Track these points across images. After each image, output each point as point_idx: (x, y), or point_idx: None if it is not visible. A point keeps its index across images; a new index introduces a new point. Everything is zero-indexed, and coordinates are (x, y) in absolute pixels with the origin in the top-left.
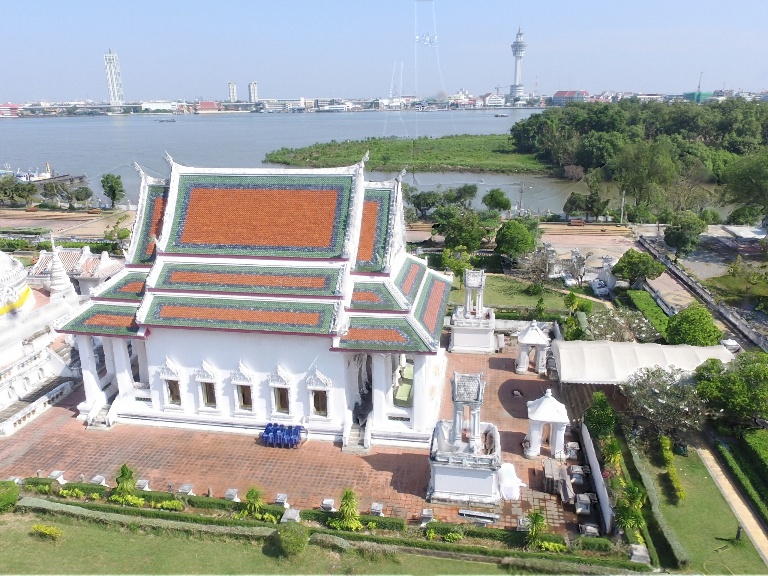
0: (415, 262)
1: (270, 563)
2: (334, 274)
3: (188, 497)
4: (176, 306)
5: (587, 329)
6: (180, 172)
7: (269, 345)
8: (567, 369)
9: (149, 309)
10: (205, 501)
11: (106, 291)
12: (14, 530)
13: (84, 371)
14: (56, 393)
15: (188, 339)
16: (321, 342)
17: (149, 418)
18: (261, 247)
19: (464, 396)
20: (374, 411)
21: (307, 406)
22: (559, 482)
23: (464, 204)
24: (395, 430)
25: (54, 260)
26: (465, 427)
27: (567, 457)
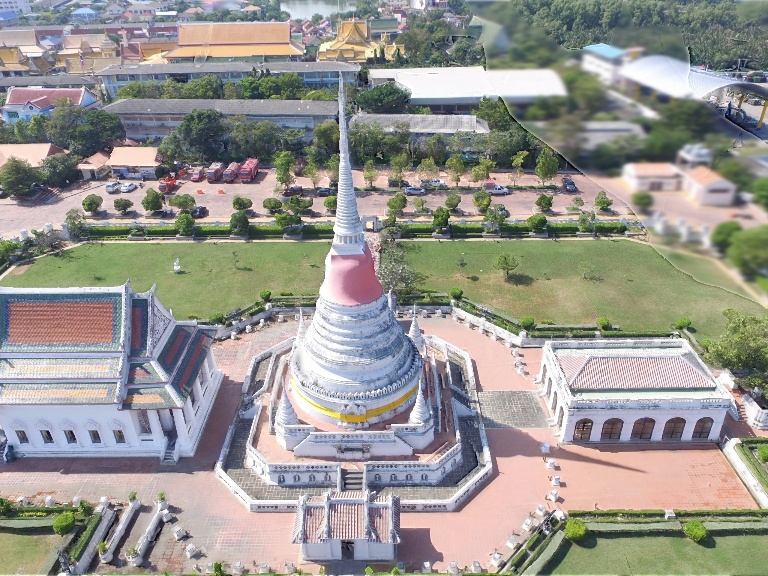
0: None
1: None
2: None
3: None
4: None
5: None
6: None
7: None
8: None
9: None
10: None
11: None
12: None
13: None
14: None
15: None
16: None
17: None
18: None
19: None
20: None
21: None
22: None
23: None
24: None
25: None
26: None
27: None
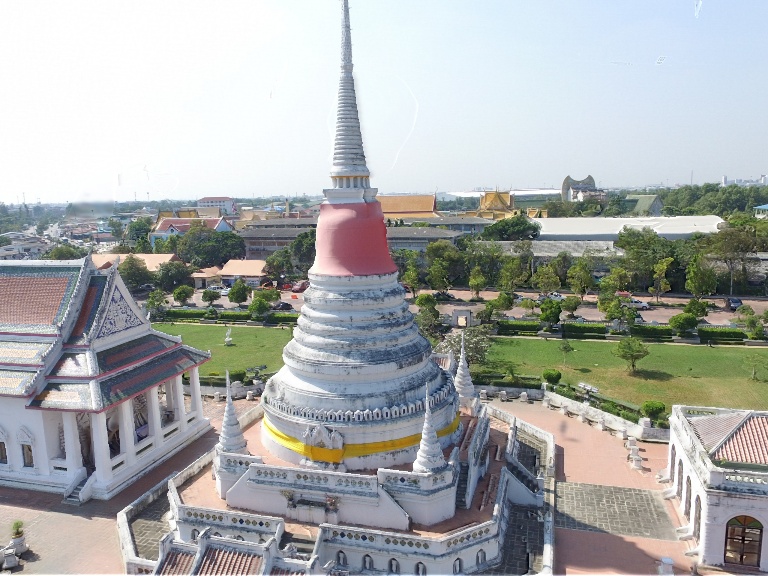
0: None
1: None
2: None
3: None
4: None
5: None
6: None
7: None
8: None
9: None
10: None
11: None
12: None
13: None
14: None
15: None
16: None
17: None
18: None
19: None
20: None
21: None
22: None
23: None
24: None
25: None
26: None
27: None
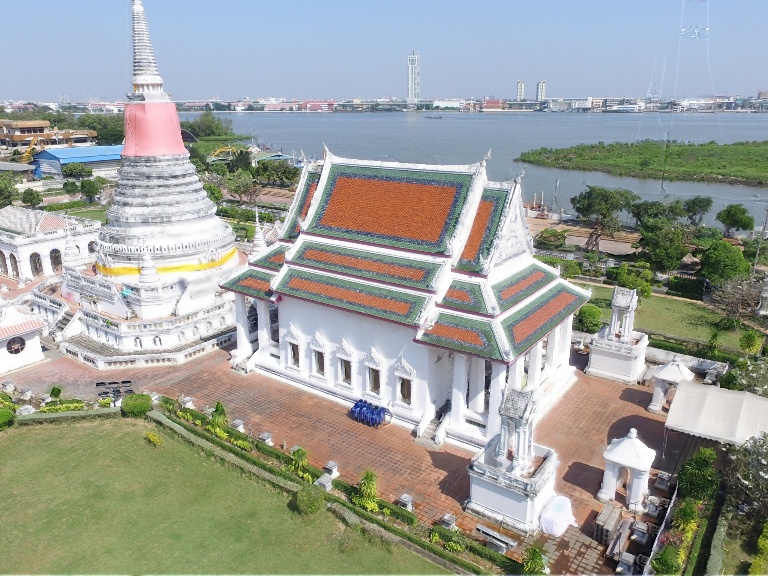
0: (542, 269)
1: (287, 515)
2: (434, 269)
3: (257, 442)
4: (302, 279)
5: (739, 376)
6: (332, 162)
7: (368, 327)
8: (676, 414)
9: (282, 278)
10: (267, 449)
11: (259, 259)
12: (138, 432)
13: (237, 323)
14: (224, 338)
15: (308, 310)
16: (410, 332)
17: (276, 373)
18: (380, 235)
19: (510, 411)
20: (452, 410)
21: (394, 391)
22: (615, 533)
23: (693, 219)
24: (468, 434)
25: (256, 231)
26: (511, 444)
27: (645, 511)
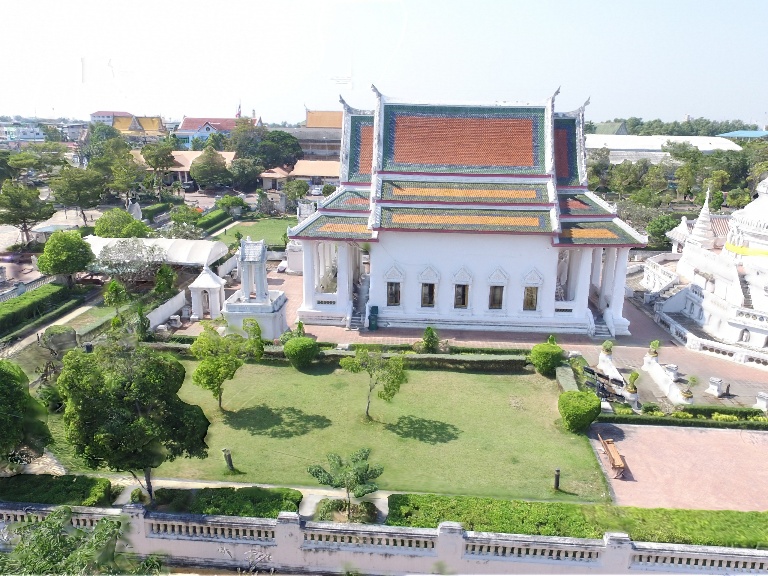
0: None
1: None
2: None
3: None
4: None
5: None
6: None
7: None
8: None
9: None
10: None
11: None
12: None
13: None
14: None
15: None
16: None
17: None
18: None
19: None
20: None
21: None
22: None
23: None
24: None
25: None
26: None
27: None
